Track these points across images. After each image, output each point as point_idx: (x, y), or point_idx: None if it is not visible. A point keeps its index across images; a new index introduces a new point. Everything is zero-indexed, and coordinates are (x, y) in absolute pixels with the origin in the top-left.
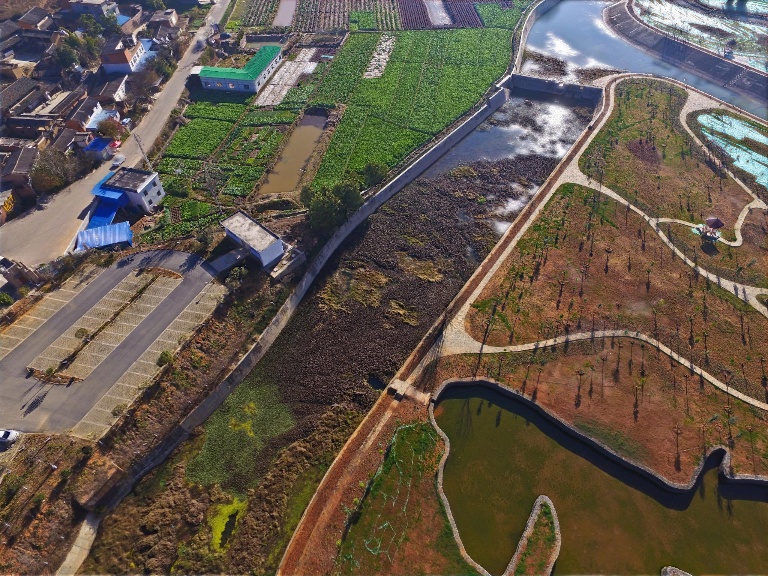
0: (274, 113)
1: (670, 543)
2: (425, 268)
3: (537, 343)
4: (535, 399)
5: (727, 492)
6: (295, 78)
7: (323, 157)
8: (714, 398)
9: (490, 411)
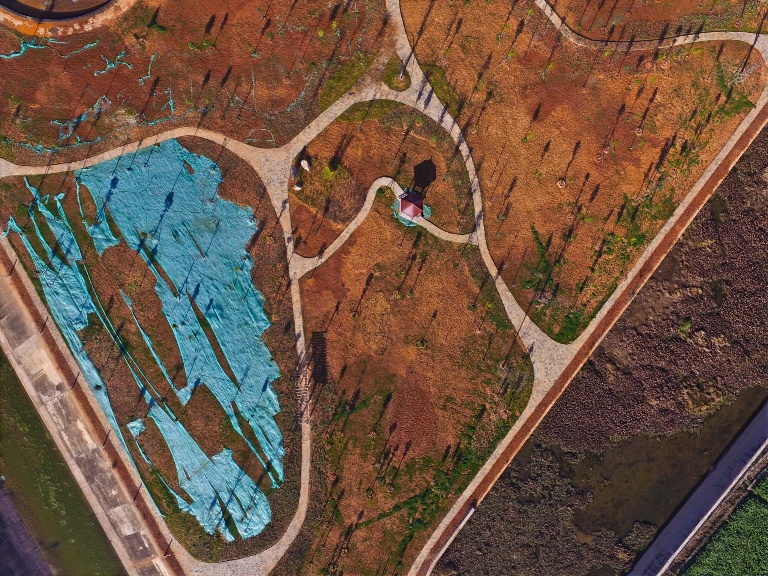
0: None
1: None
2: None
3: (696, 40)
4: None
5: None
6: None
7: None
8: None
9: None
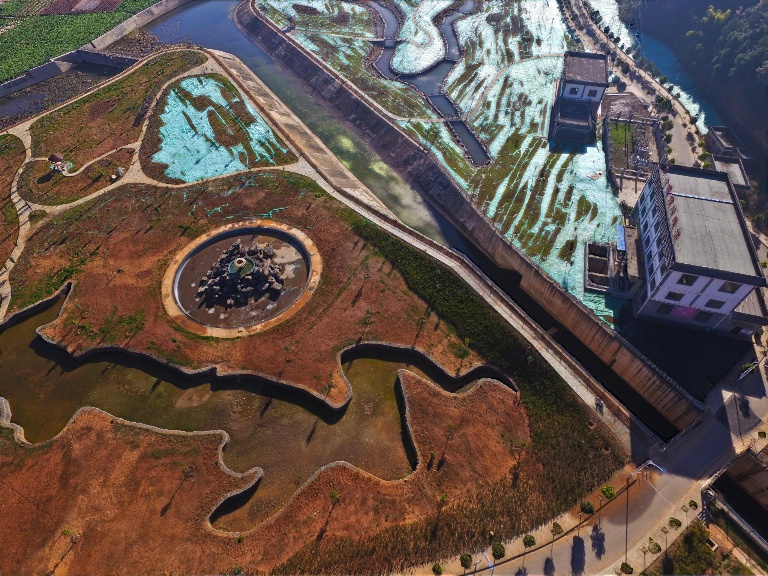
0: None
1: None
2: None
3: None
4: None
5: None
6: None
7: None
8: None
9: None
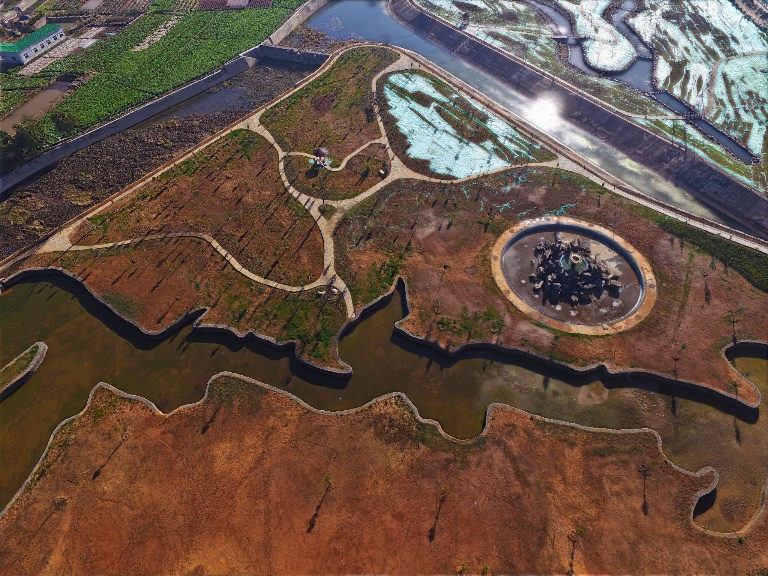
0: (28, 80)
1: (121, 370)
2: (82, 196)
3: (116, 243)
4: (84, 280)
5: (193, 338)
6: (68, 52)
7: (47, 113)
8: (226, 276)
9: (49, 291)
